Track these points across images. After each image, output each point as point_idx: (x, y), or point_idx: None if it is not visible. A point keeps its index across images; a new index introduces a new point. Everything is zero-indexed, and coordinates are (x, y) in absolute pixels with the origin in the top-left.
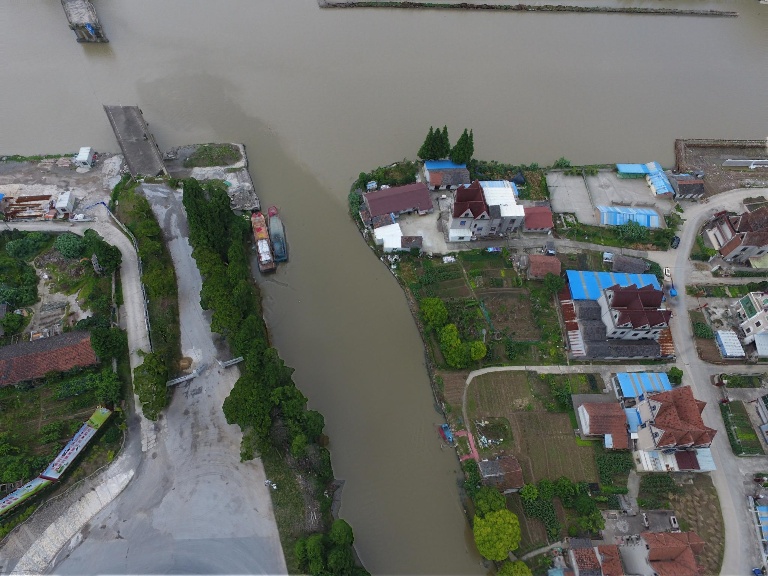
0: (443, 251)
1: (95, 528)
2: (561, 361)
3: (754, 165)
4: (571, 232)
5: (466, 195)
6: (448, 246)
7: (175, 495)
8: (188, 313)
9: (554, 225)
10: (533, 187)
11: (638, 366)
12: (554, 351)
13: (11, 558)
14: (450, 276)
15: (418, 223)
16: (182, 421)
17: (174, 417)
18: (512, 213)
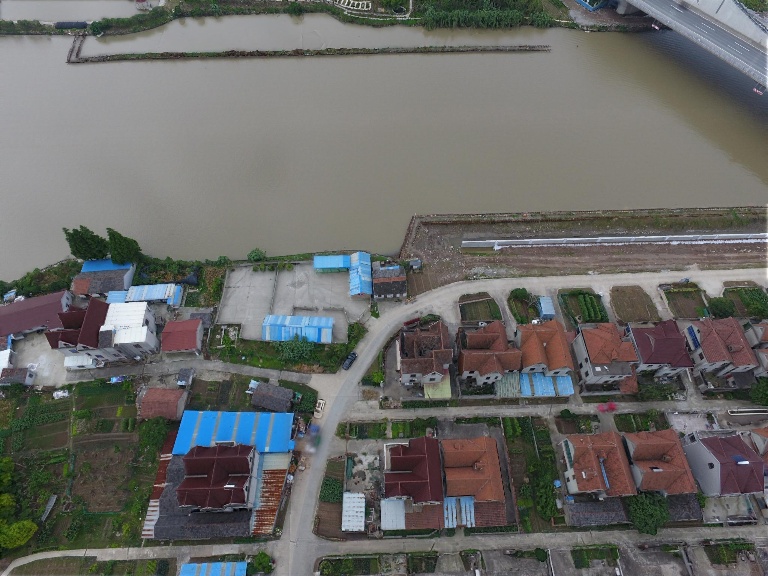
0: (59, 383)
1: None
2: (133, 541)
3: (499, 245)
4: (224, 352)
5: (73, 319)
6: (68, 376)
7: None
8: None
9: (207, 342)
10: (208, 289)
11: (229, 546)
12: (126, 528)
13: None
14: (50, 419)
15: (46, 344)
16: None
17: None
18: (130, 338)
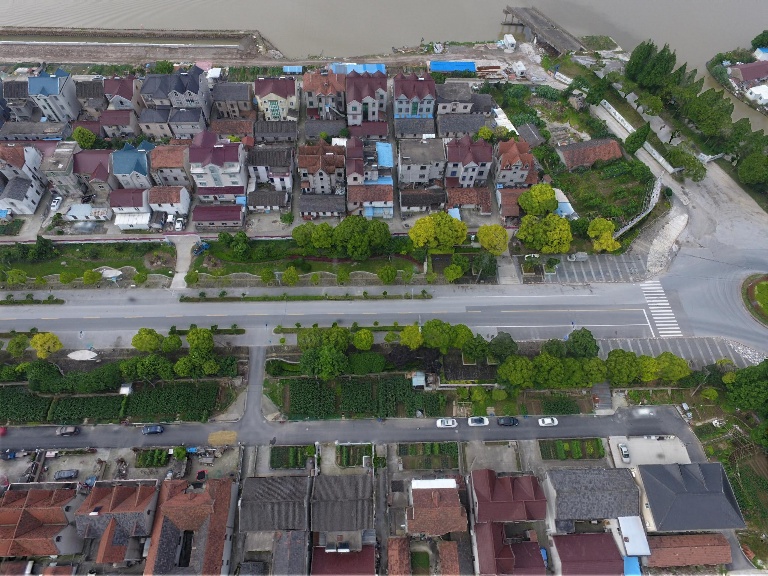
0: None
1: (683, 242)
2: None
3: None
4: None
5: None
6: None
7: (722, 227)
8: (660, 132)
9: None
10: None
11: None
12: None
13: (642, 255)
14: None
15: None
16: (699, 190)
17: (692, 188)
18: None
